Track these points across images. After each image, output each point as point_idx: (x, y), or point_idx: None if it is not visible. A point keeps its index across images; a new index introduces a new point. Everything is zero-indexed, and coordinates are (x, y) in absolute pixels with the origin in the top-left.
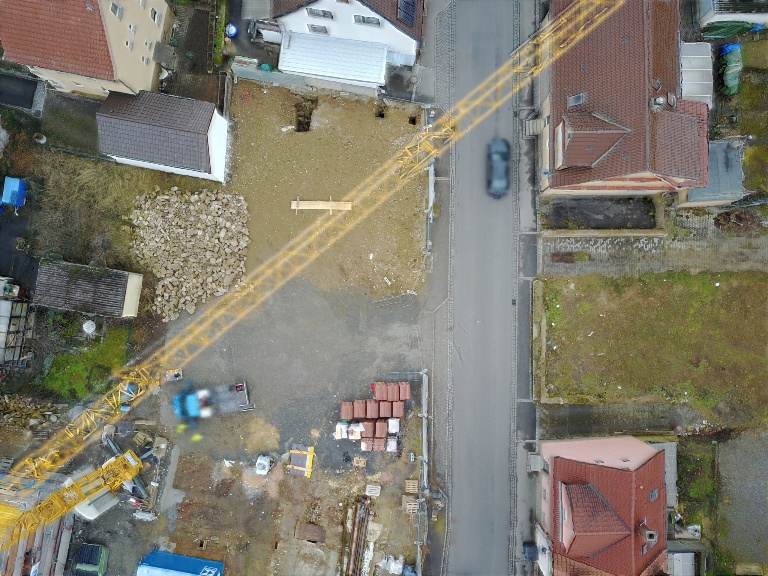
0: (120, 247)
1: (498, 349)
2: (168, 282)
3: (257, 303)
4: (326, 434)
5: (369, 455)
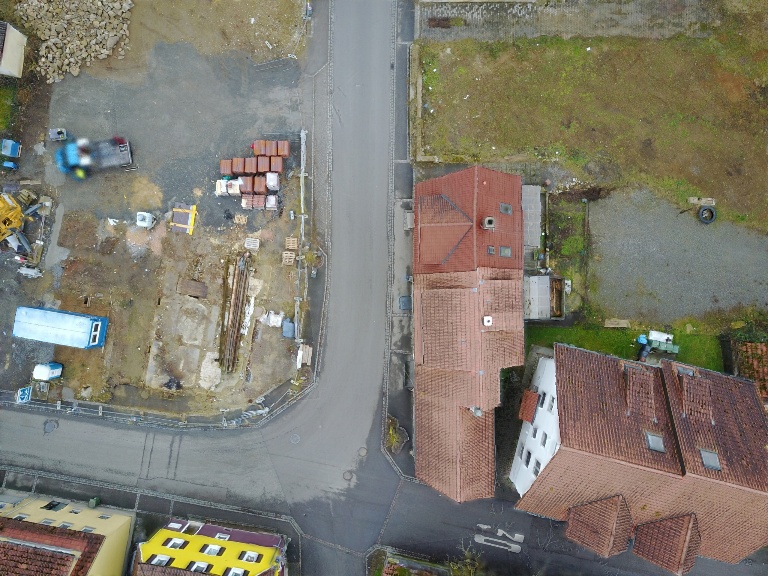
0: (5, 10)
1: (377, 112)
2: (52, 43)
3: (141, 66)
4: (208, 193)
5: (250, 213)
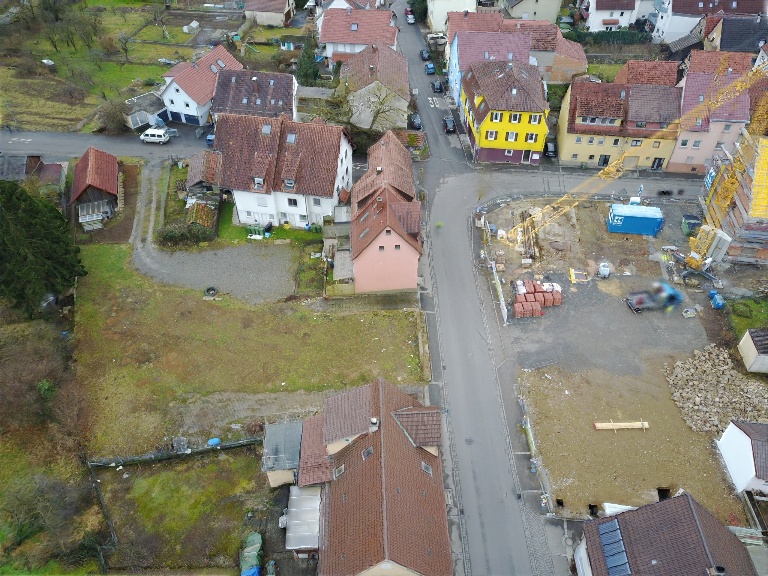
0: None
1: (453, 340)
2: None
3: (647, 359)
4: (566, 289)
5: None
